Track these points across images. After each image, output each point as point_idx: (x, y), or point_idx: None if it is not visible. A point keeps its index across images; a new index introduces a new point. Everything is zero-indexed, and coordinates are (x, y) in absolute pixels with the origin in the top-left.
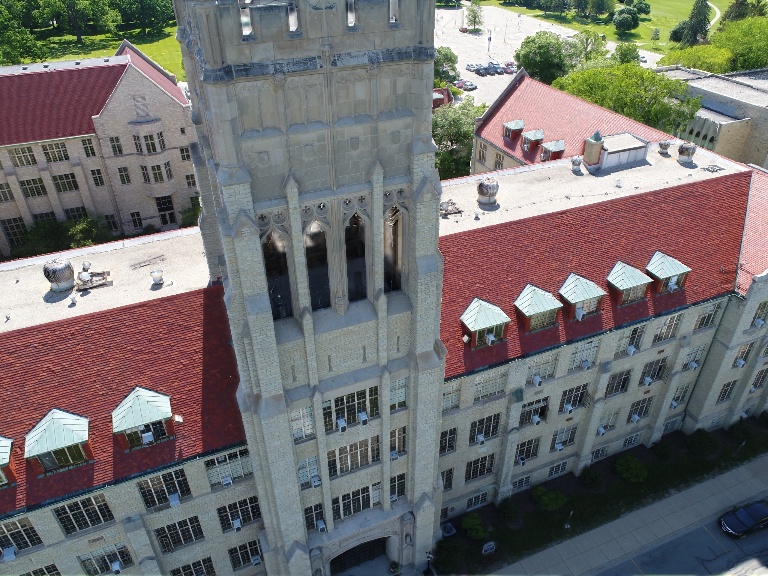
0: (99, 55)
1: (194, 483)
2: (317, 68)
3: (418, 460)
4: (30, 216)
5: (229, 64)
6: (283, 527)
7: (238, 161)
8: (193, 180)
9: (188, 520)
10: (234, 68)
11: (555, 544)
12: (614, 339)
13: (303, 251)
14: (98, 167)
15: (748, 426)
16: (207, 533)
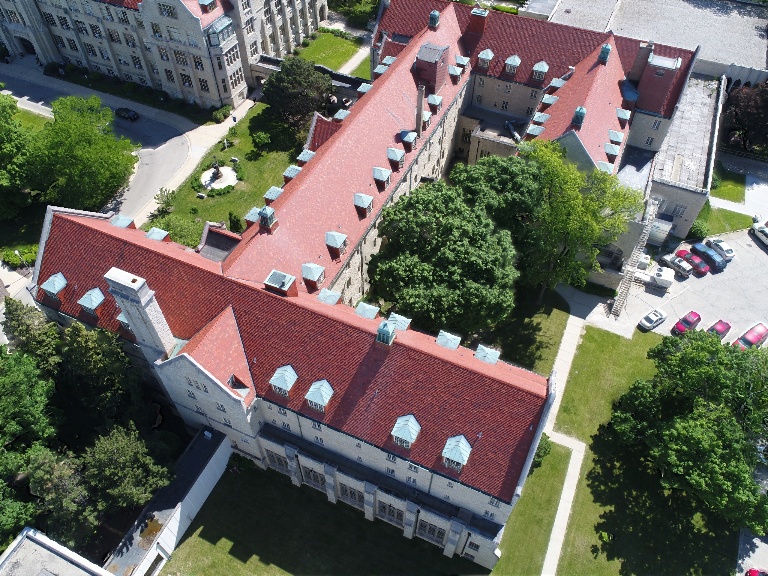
0: None
1: None
2: None
3: (18, 6)
4: None
5: None
6: None
7: None
8: None
9: None
10: None
11: (80, 85)
12: (96, 6)
13: None
14: None
15: (180, 101)
16: None
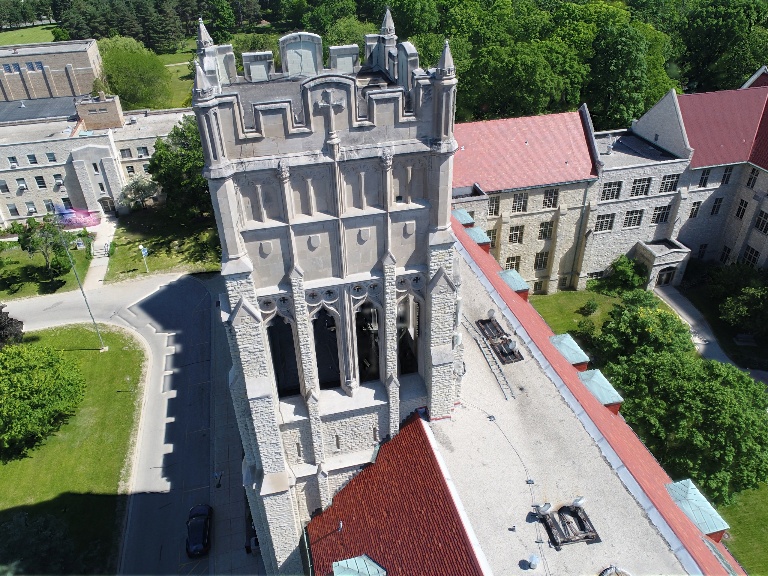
0: None
1: None
2: None
3: None
4: (766, 258)
5: None
6: None
7: None
8: None
9: None
10: None
11: None
12: None
13: None
14: None
15: None
16: None
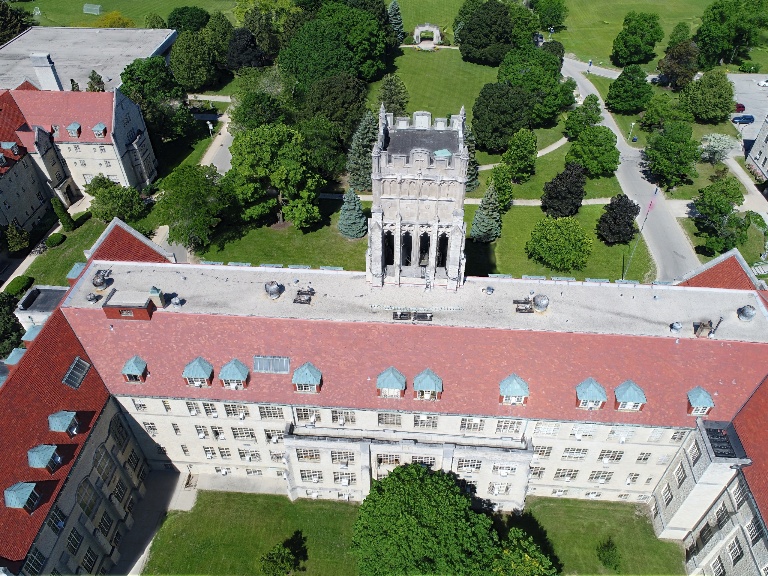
0: None
1: None
2: None
3: None
4: None
5: None
6: None
7: None
8: None
9: None
10: None
11: None
12: None
13: None
14: None
15: None
16: None
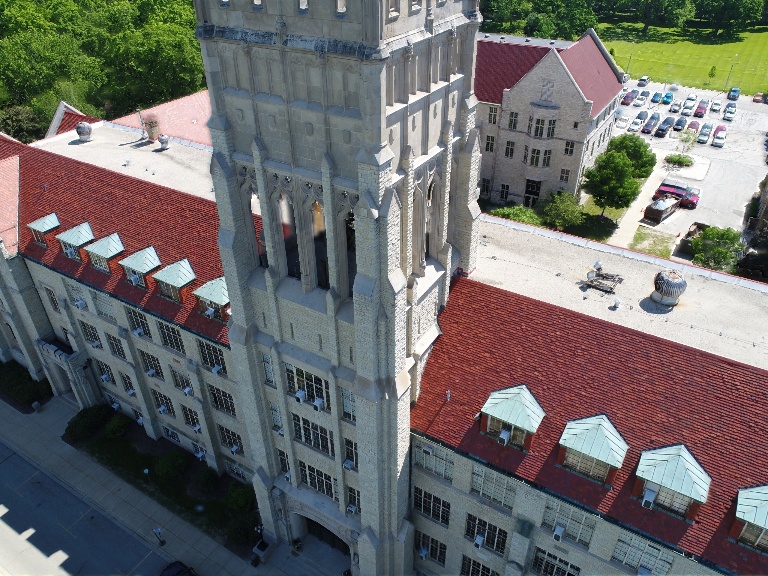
0: (648, 46)
1: (228, 367)
2: (271, 44)
3: (362, 486)
4: None
5: (214, 24)
6: (252, 446)
7: (219, 110)
8: (567, 176)
9: (228, 394)
10: (216, 28)
11: None
12: (700, 575)
13: (267, 212)
14: (493, 135)
15: None
16: (237, 415)
